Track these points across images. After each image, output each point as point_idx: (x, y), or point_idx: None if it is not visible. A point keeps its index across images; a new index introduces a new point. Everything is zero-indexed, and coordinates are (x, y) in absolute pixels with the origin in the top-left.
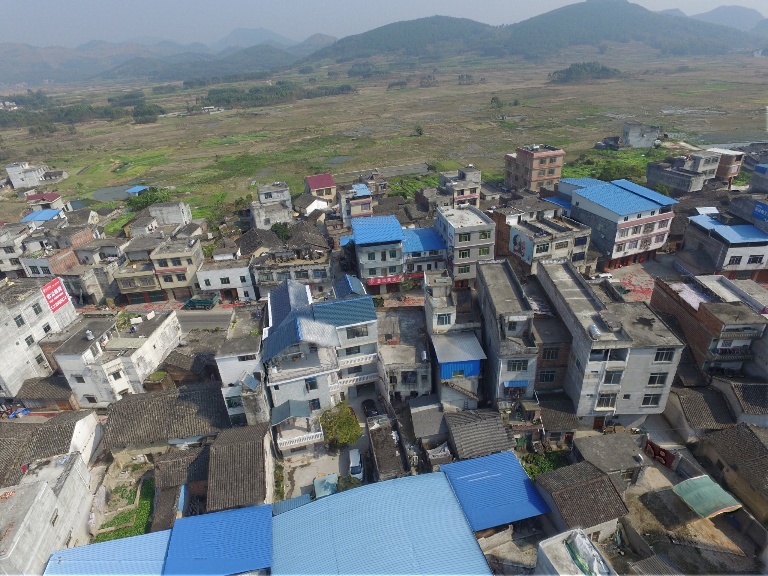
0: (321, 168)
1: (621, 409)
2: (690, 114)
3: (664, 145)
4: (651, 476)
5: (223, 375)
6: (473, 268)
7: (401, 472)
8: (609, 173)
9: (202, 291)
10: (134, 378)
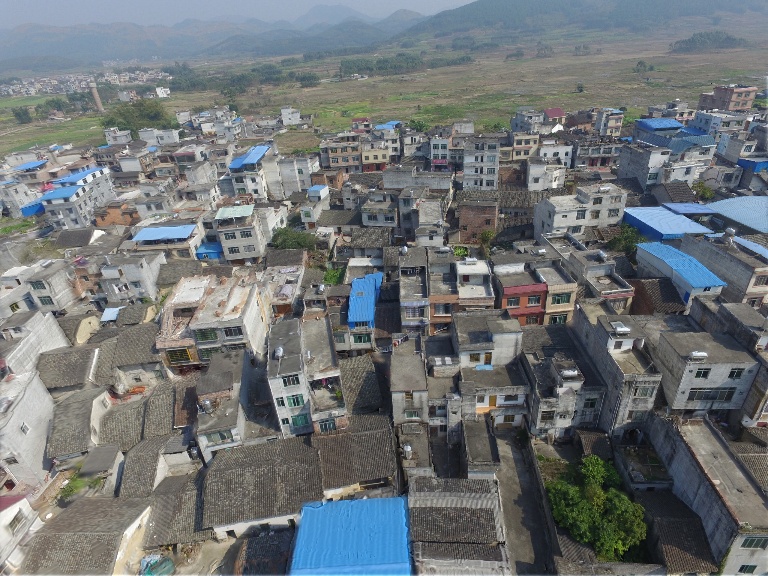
0: None
1: None
2: None
3: None
4: None
5: (650, 162)
6: None
7: None
8: None
9: None
10: (561, 183)
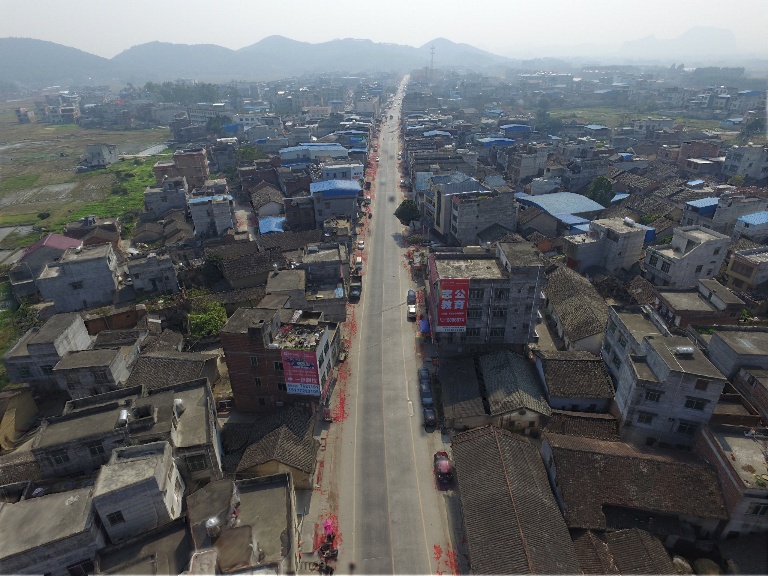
0: None
1: None
2: (32, 146)
3: (125, 158)
4: None
5: None
6: None
7: None
8: (251, 153)
9: None
10: None
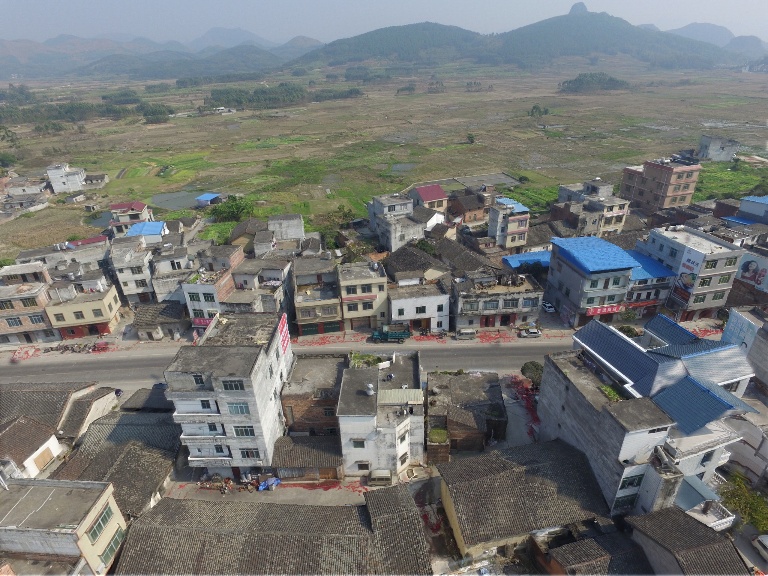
0: (392, 176)
1: None
2: (734, 128)
3: (744, 159)
4: None
5: (624, 450)
6: (709, 297)
7: None
8: (765, 190)
9: (387, 321)
10: (417, 440)
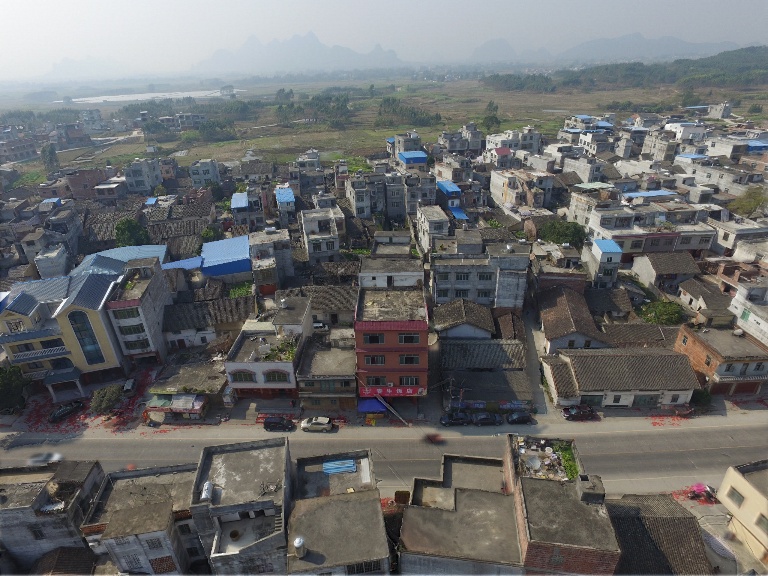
0: None
1: None
2: None
3: None
4: None
5: None
6: None
7: None
8: None
9: None
10: None
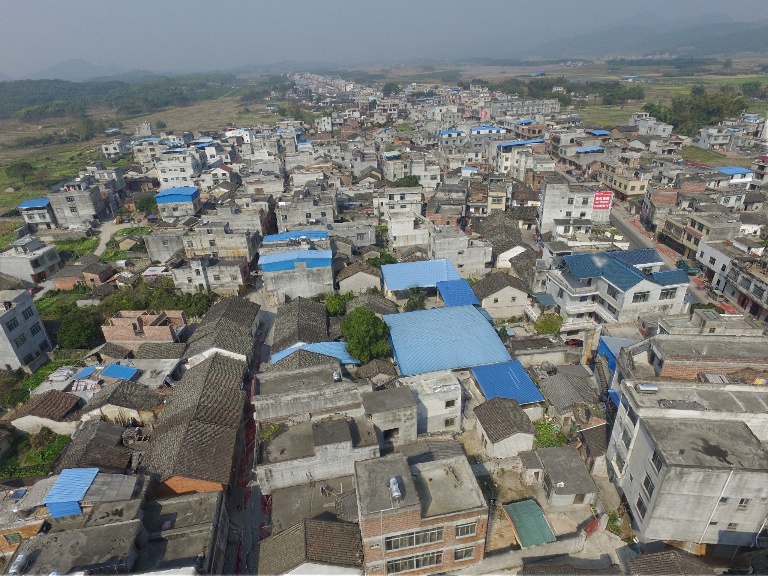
0: None
1: (626, 488)
2: None
3: None
4: (564, 520)
5: (543, 256)
6: None
7: (514, 350)
8: None
9: None
10: None
